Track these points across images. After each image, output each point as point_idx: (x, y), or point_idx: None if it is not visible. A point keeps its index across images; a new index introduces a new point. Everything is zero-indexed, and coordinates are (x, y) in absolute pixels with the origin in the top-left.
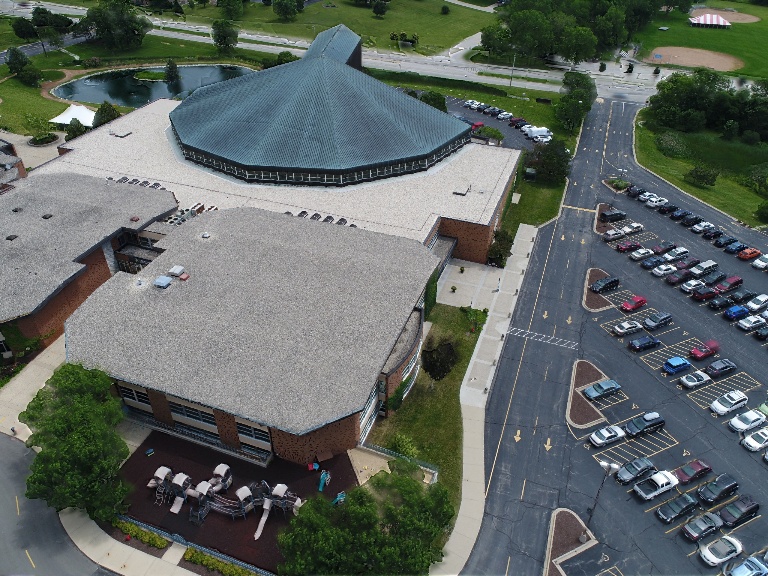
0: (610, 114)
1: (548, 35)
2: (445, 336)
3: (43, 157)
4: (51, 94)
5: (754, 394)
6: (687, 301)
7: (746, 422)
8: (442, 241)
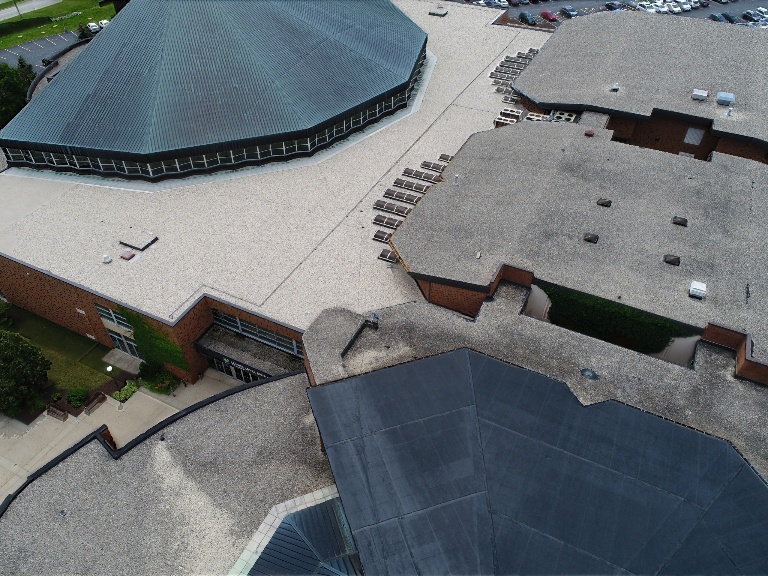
0: None
1: None
2: None
3: (4, 477)
4: None
5: (636, 2)
6: (538, 5)
7: (664, 7)
8: None
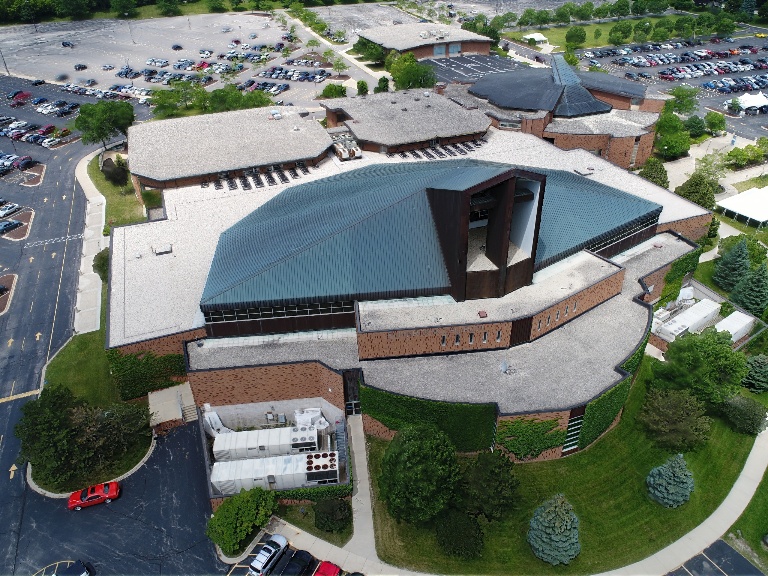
0: None
1: None
2: (130, 215)
3: None
4: None
5: None
6: None
7: None
8: None
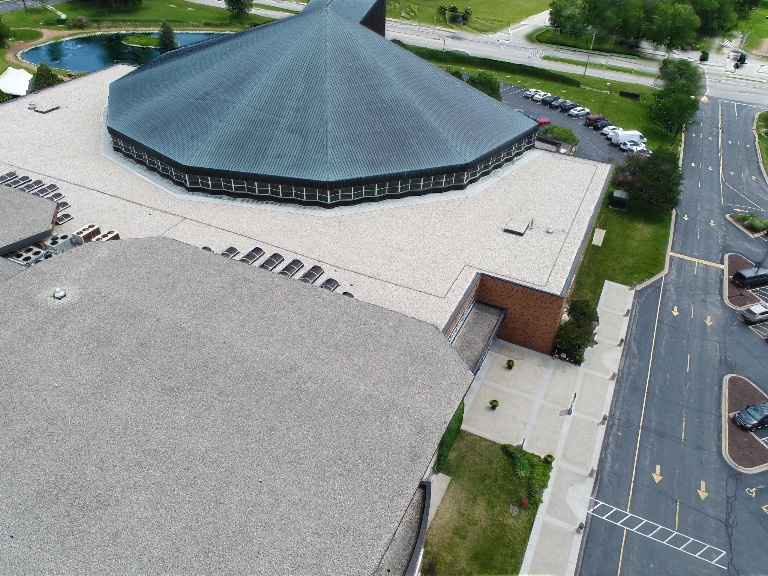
0: (720, 117)
1: (636, 13)
2: (471, 512)
3: None
4: (16, 56)
5: None
6: None
7: None
8: (480, 313)
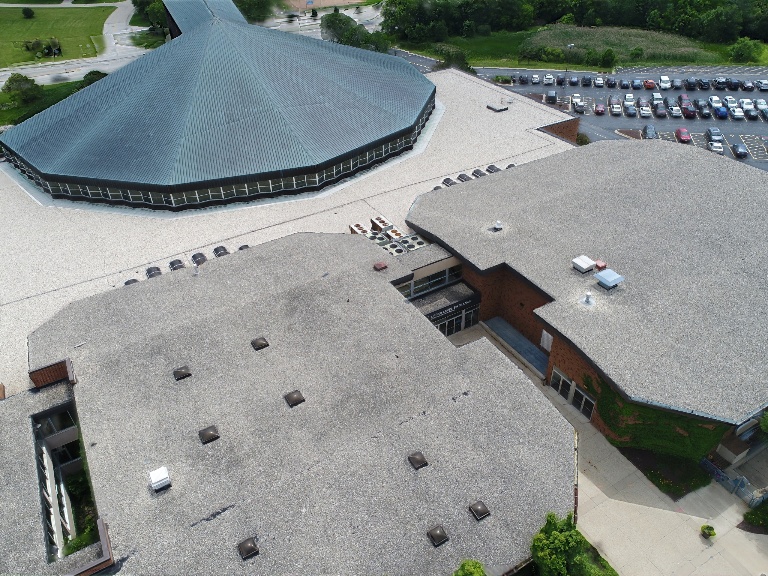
0: None
1: None
2: None
3: None
4: None
5: None
6: (690, 121)
7: None
8: None
